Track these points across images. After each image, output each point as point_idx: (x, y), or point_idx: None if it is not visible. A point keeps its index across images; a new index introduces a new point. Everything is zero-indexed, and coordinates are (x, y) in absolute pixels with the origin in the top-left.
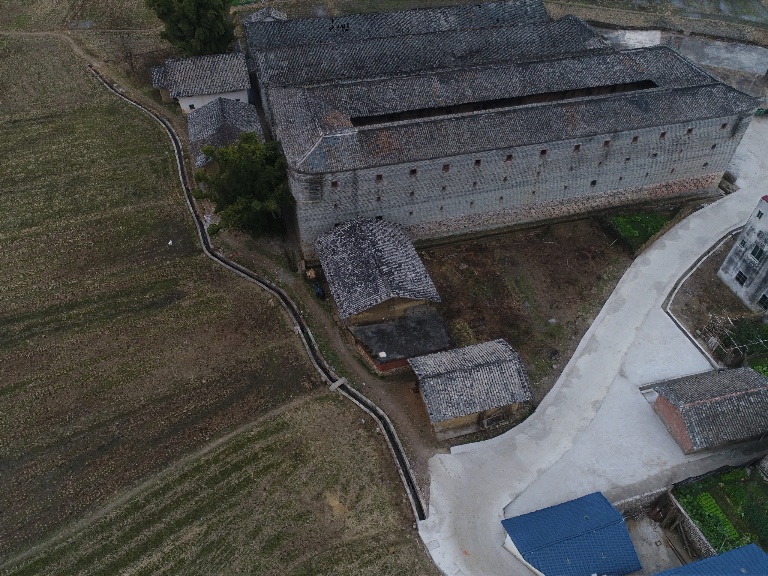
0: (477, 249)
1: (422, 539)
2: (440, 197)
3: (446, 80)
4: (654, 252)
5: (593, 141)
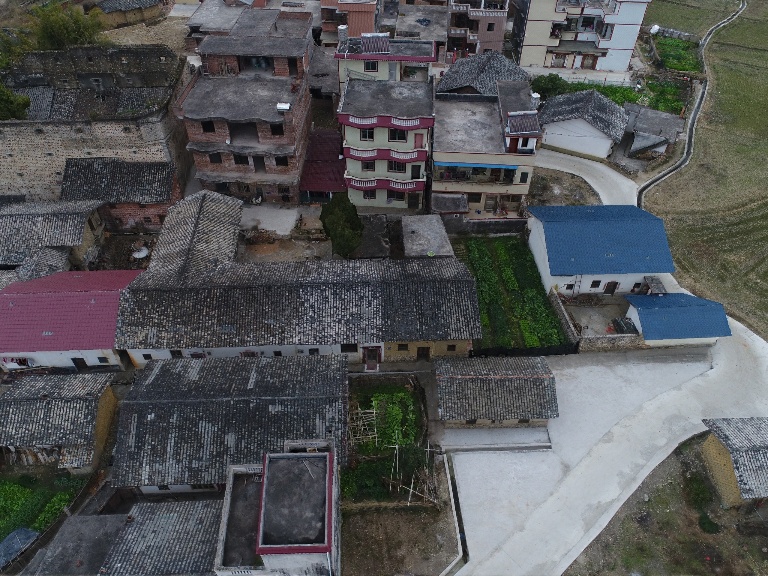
0: None
1: None
2: None
3: None
4: None
5: None
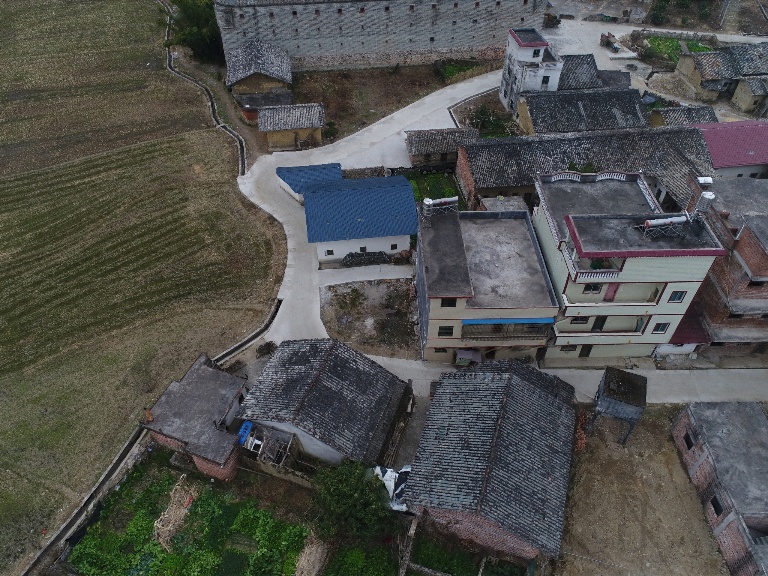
0: (343, 76)
1: (237, 181)
2: (317, 36)
3: None
4: (463, 84)
5: (423, 4)
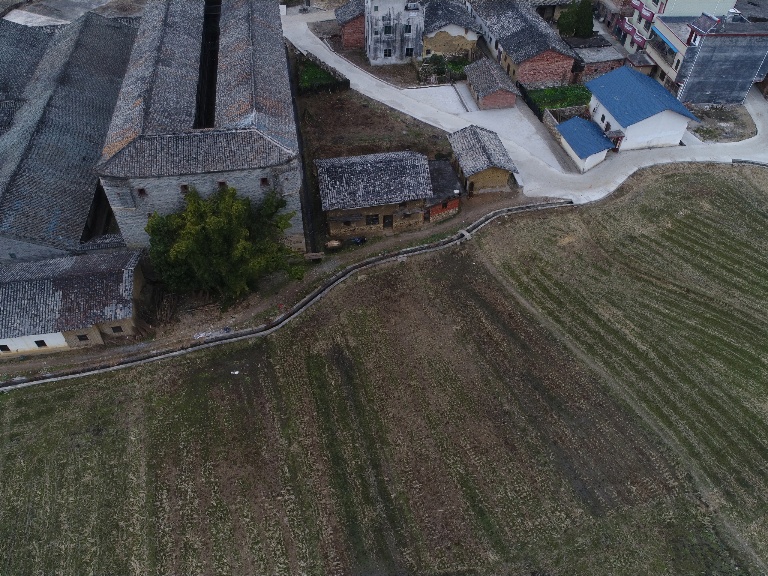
0: (320, 151)
1: (585, 203)
2: None
3: (166, 63)
4: None
5: None
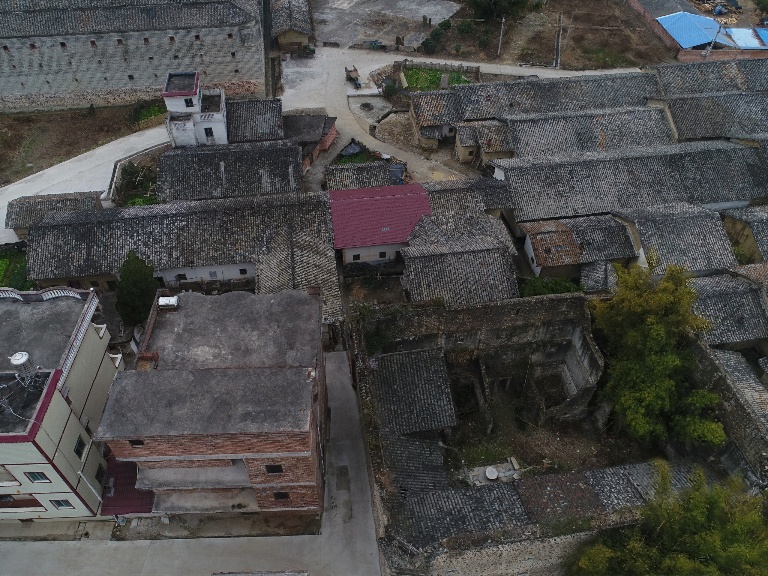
0: (26, 120)
1: None
2: None
3: None
4: (155, 130)
5: (106, 39)
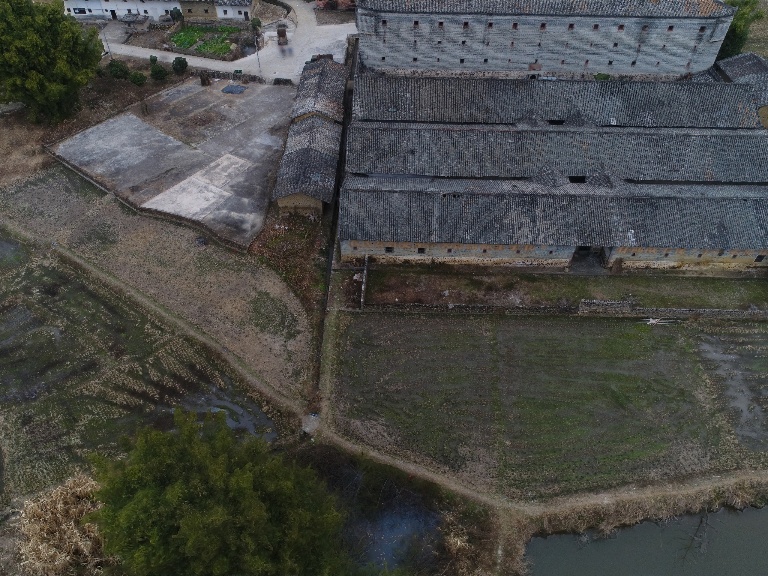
0: None
1: None
2: None
3: None
4: None
5: None
